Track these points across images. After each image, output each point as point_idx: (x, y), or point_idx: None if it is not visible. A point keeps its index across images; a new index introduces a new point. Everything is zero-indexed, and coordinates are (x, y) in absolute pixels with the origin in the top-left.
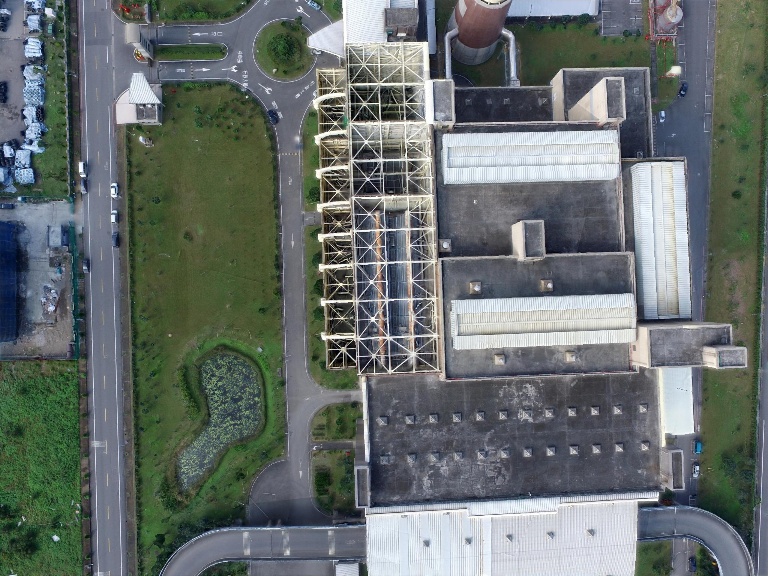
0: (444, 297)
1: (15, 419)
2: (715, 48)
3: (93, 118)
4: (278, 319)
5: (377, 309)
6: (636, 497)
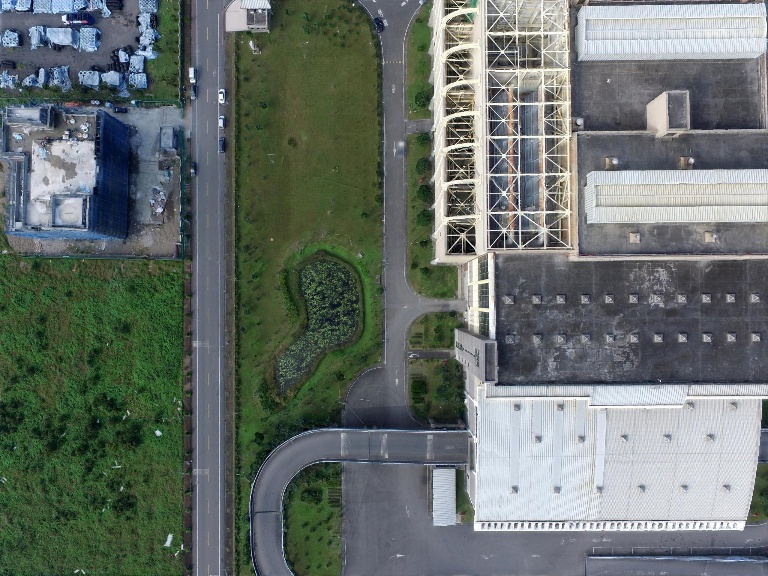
0: (578, 173)
1: (123, 316)
2: None
3: (203, 26)
4: (379, 226)
5: (506, 186)
6: None
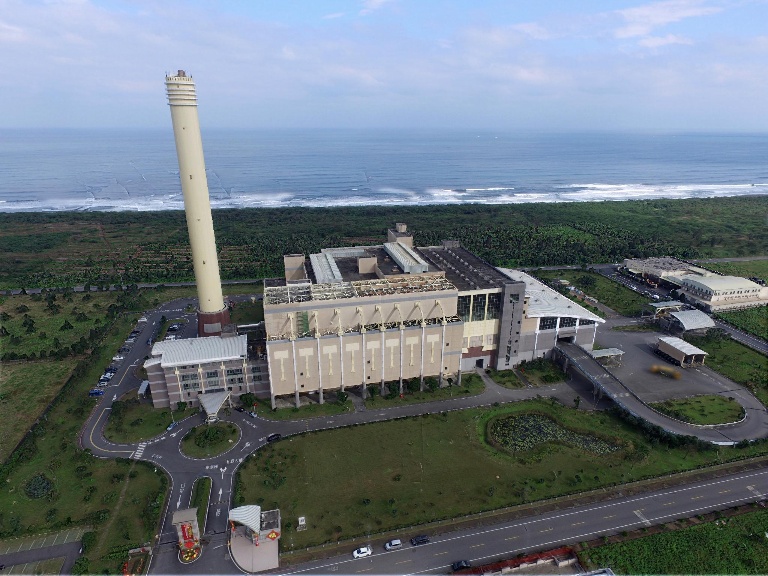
0: None
1: None
2: None
3: None
4: None
5: None
6: None
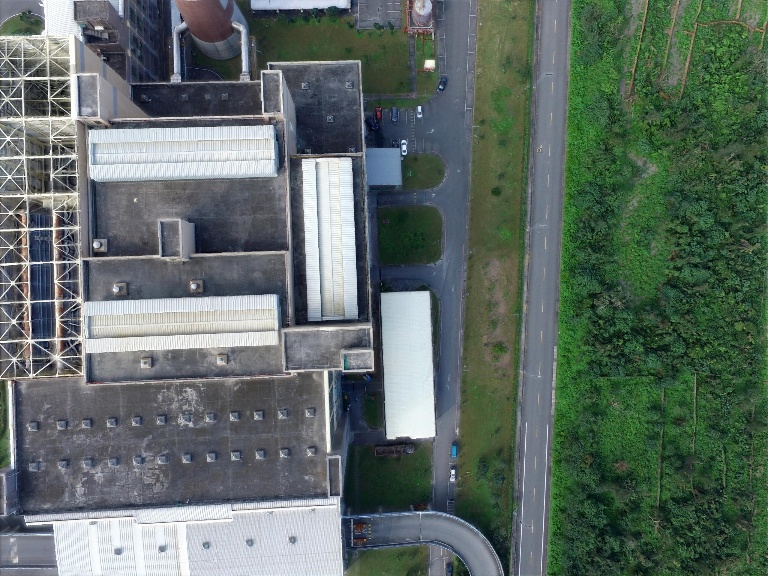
0: (89, 299)
1: None
2: (476, 41)
3: None
4: None
5: None
6: (313, 504)
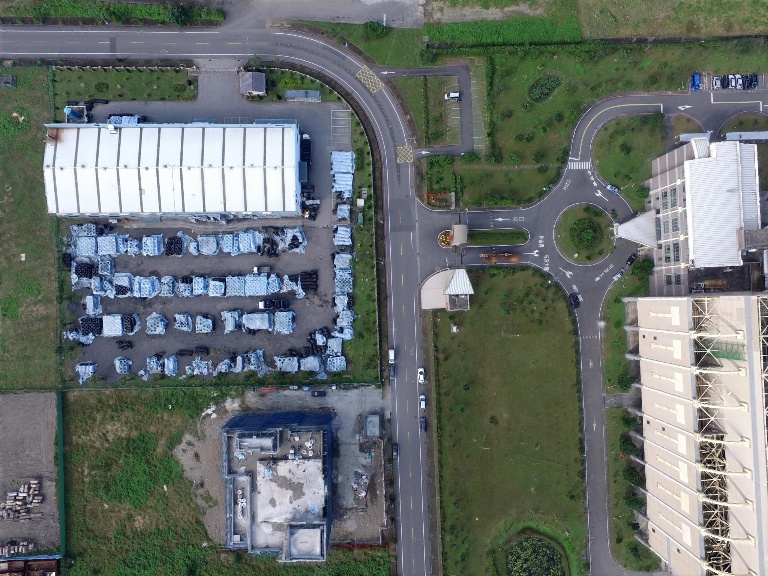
0: None
1: None
2: None
3: (399, 304)
4: (583, 502)
5: None
6: None
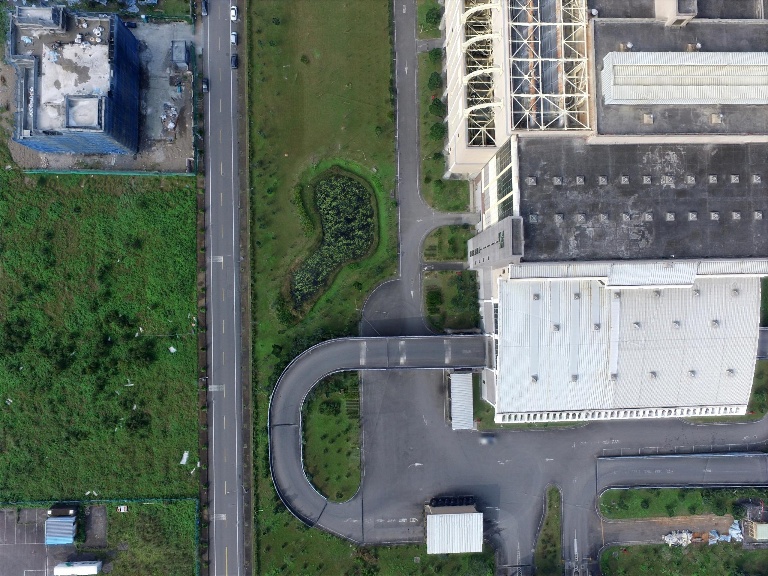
0: None
1: (134, 232)
2: None
3: None
4: (392, 141)
5: None
6: None
